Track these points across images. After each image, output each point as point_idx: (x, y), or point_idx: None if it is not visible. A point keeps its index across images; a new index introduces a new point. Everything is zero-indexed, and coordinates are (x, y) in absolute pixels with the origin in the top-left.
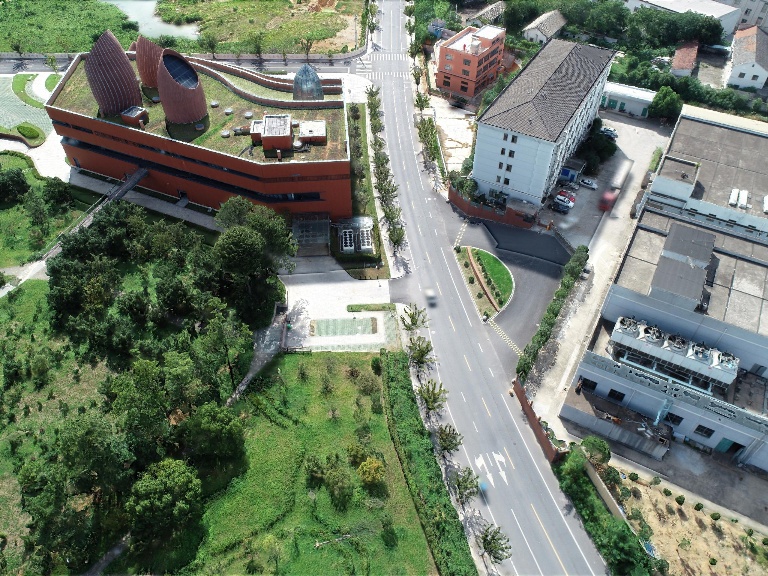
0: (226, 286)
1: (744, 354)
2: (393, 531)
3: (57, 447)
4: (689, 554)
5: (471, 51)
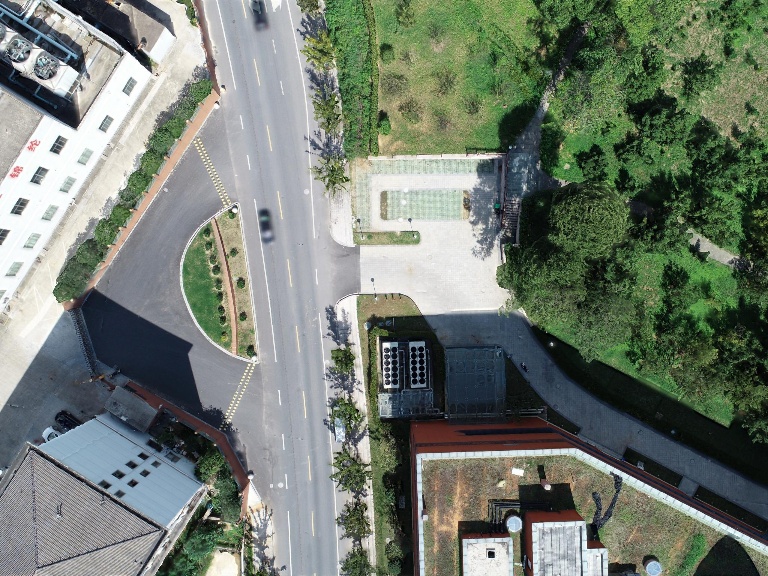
0: (592, 259)
1: None
2: None
3: (744, 8)
4: None
5: None
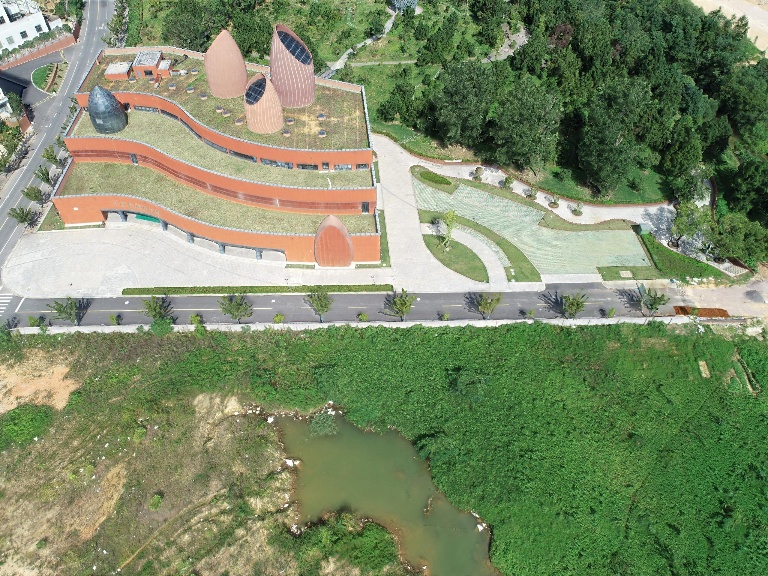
0: None
1: None
2: None
3: None
4: (52, 5)
5: None
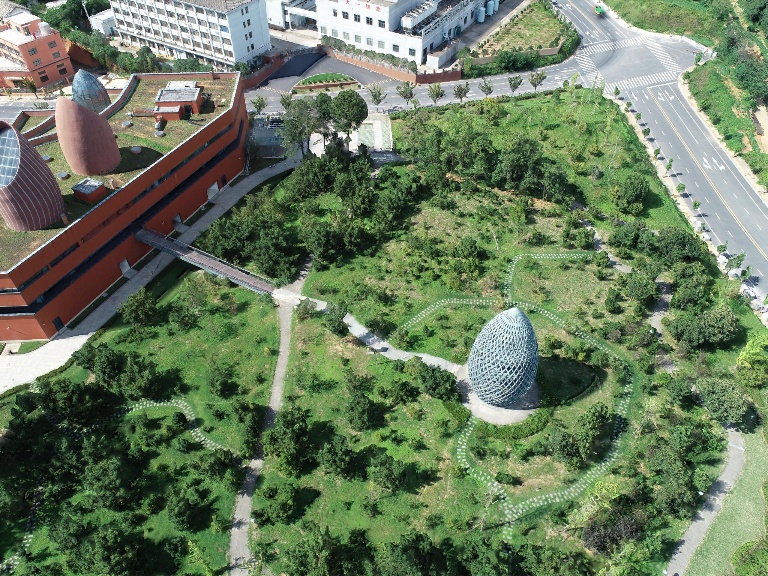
0: None
1: (422, 2)
2: None
3: None
4: None
5: (47, 33)
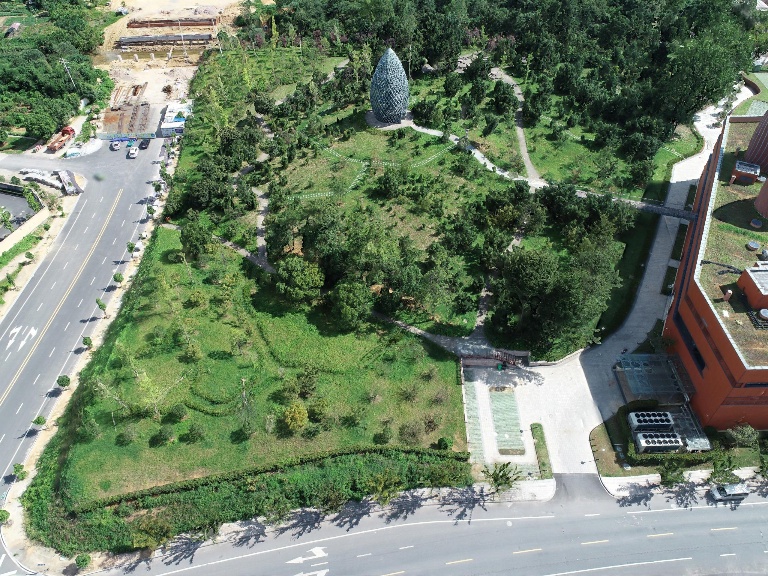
0: None
1: None
2: (244, 440)
3: None
4: None
5: None
